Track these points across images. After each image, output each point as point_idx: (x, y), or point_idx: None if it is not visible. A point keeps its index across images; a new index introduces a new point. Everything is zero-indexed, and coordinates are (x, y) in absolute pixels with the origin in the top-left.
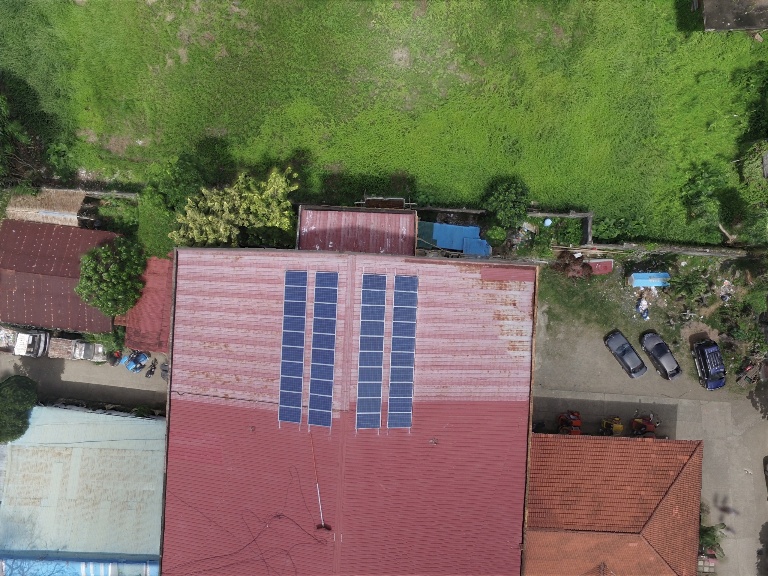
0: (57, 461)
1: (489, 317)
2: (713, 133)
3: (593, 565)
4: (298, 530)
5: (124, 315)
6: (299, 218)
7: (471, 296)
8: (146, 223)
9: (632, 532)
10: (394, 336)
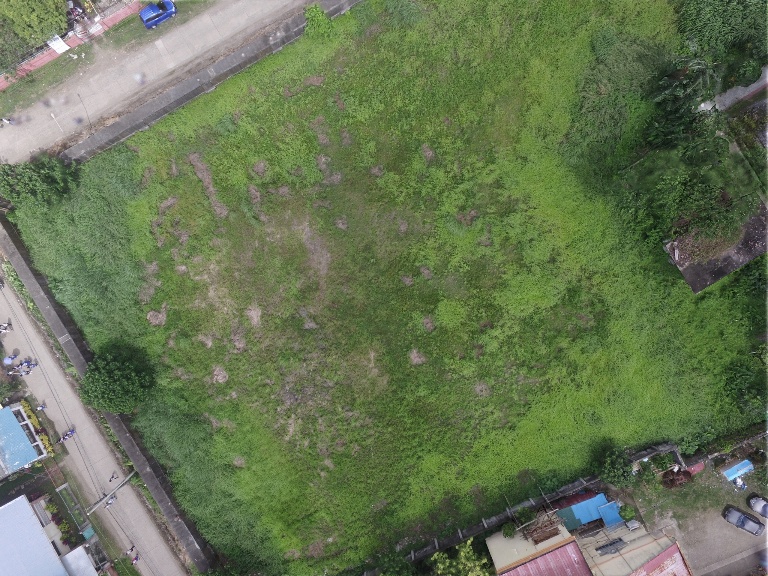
0: None
1: None
2: (727, 339)
3: None
4: None
5: None
6: None
7: None
8: None
9: None
10: None
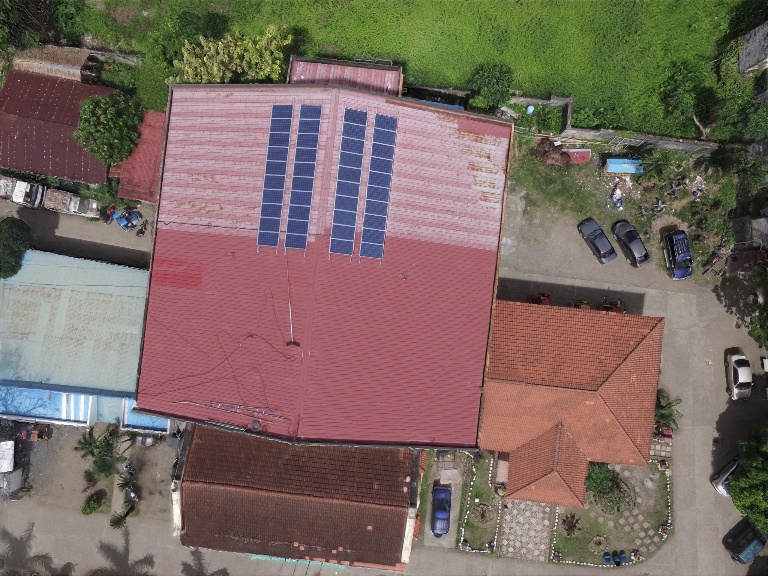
0: (46, 301)
1: (464, 166)
2: (694, 34)
3: (551, 424)
4: (269, 348)
5: (119, 167)
6: (290, 66)
7: (448, 144)
8: (145, 78)
9: (589, 389)
10: (371, 170)
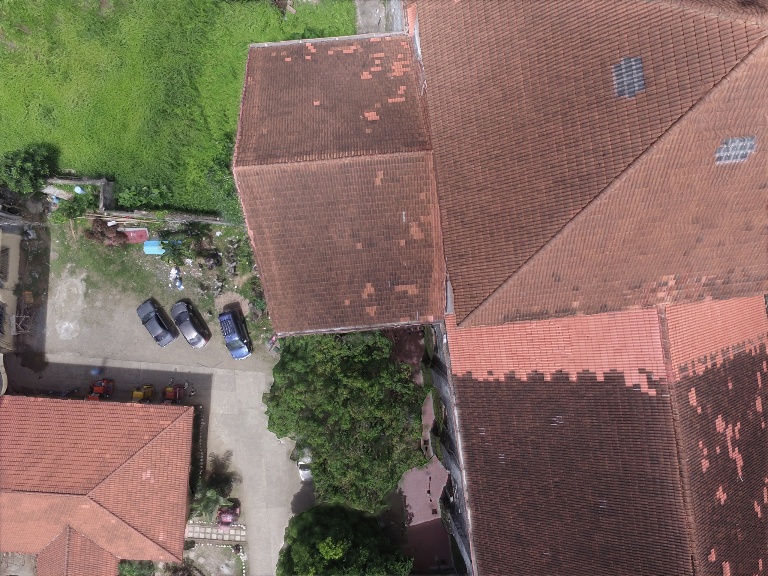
0: None
1: None
2: None
3: (61, 527)
4: None
5: None
6: None
7: None
8: None
9: (79, 494)
10: None
